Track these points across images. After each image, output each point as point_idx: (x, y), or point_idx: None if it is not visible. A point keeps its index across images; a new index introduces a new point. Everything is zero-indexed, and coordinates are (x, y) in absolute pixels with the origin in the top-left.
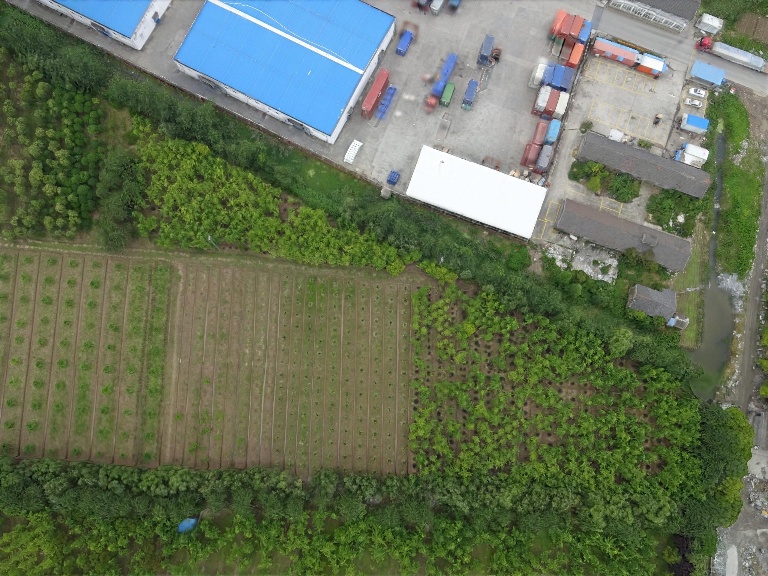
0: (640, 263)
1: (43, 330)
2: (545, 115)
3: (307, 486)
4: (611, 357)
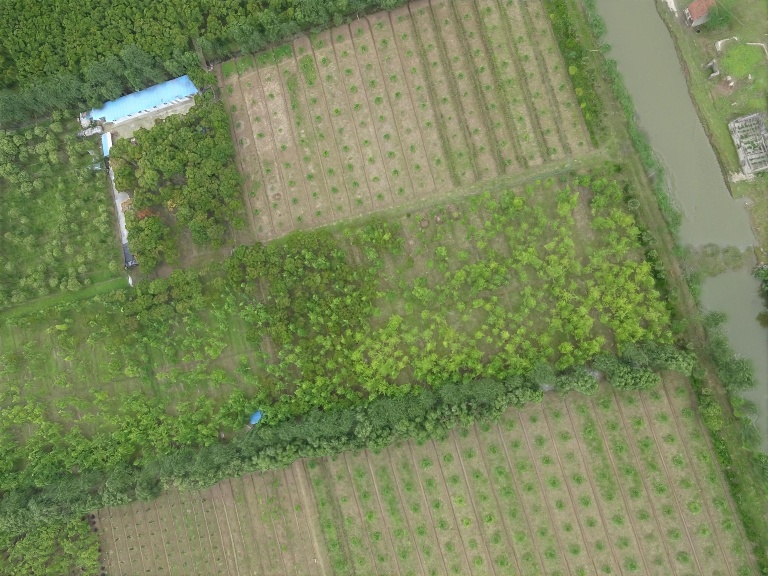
0: None
1: (455, 559)
2: None
3: None
4: None
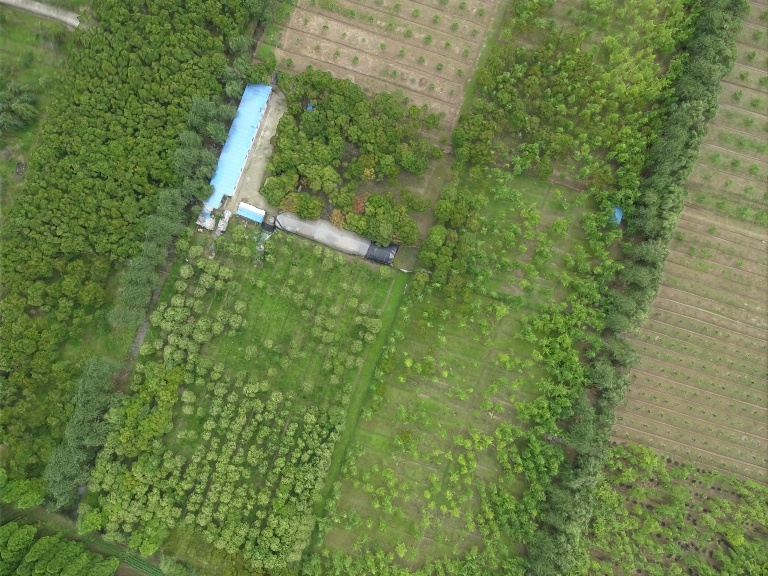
0: None
1: None
2: None
3: None
4: None
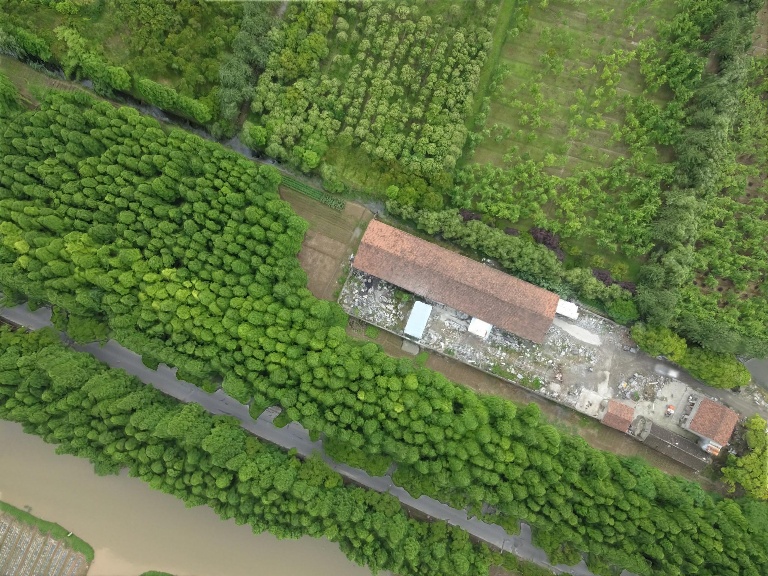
0: None
1: None
2: None
3: None
4: None
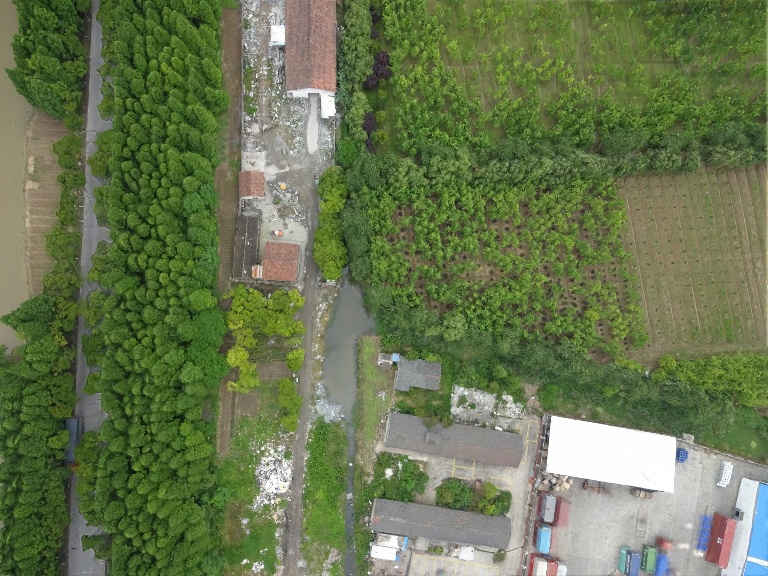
0: (434, 413)
1: None
2: (549, 558)
3: (703, 156)
4: (459, 310)
